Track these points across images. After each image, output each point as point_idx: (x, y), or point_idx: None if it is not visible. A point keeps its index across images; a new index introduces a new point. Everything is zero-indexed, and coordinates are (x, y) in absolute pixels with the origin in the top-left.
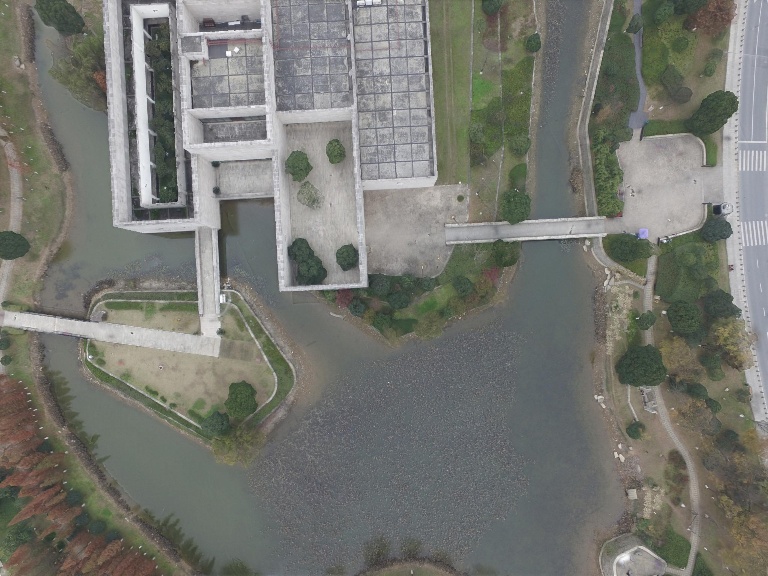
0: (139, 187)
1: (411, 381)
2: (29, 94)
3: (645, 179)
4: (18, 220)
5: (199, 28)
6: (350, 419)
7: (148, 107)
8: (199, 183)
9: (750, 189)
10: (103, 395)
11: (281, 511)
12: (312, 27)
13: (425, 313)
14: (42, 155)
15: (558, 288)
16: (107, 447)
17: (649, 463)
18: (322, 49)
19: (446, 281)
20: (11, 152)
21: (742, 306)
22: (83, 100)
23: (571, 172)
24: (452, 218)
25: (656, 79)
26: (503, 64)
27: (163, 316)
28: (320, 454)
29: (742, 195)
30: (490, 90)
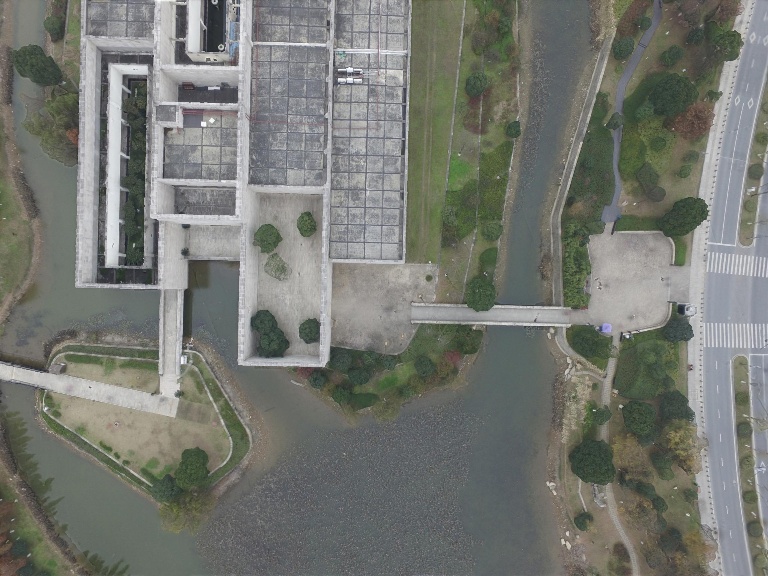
0: (105, 246)
1: (366, 454)
2: (3, 137)
3: (613, 273)
4: None
5: (178, 90)
6: (303, 487)
7: (121, 164)
8: (165, 250)
9: (715, 291)
10: None
11: (227, 573)
12: (291, 102)
13: (385, 389)
14: (12, 200)
15: (519, 372)
16: (61, 489)
17: (594, 553)
18: (299, 125)
19: (408, 359)
20: None
21: (698, 406)
22: (54, 156)
23: (541, 259)
24: (419, 297)
25: (632, 175)
26: (482, 147)
27: (123, 373)
28: (270, 520)
29: (707, 296)
30: (467, 172)
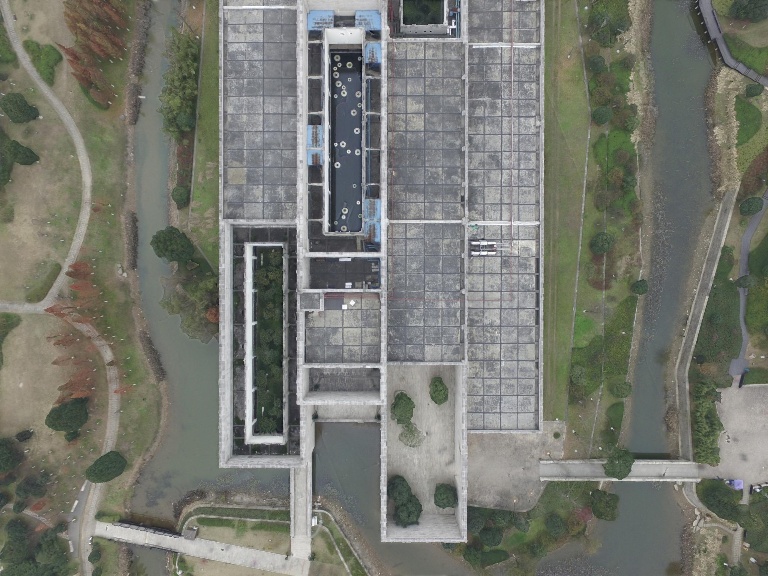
0: None
1: None
2: (130, 302)
3: (741, 426)
4: (114, 431)
5: (309, 262)
6: None
7: None
8: (306, 428)
9: None
10: None
11: None
12: (427, 278)
13: (514, 545)
14: (140, 365)
15: (646, 523)
16: None
17: None
18: (436, 301)
19: (537, 516)
20: None
21: None
22: (194, 337)
23: (666, 410)
24: (547, 454)
25: (759, 329)
26: (606, 302)
27: (254, 535)
28: None
29: None
30: (592, 328)
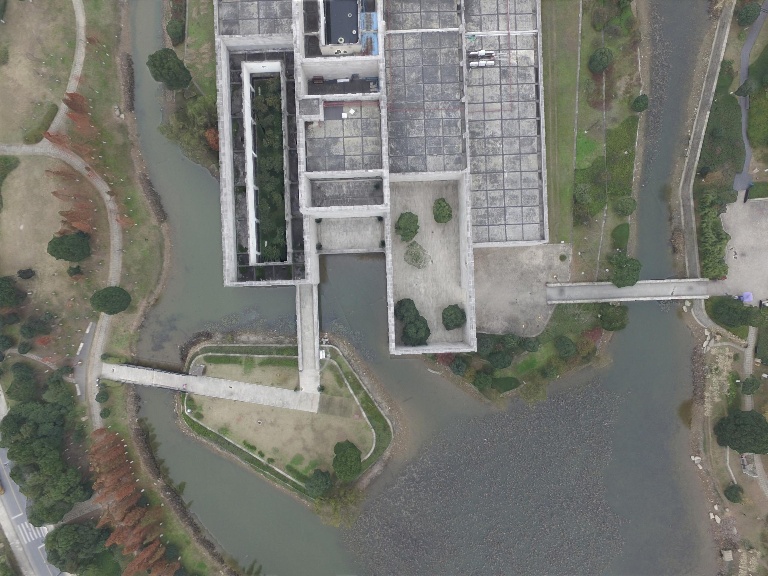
0: None
1: (508, 439)
2: (128, 144)
3: (748, 241)
4: (117, 272)
5: (307, 85)
6: (446, 475)
7: (253, 162)
8: (310, 244)
9: None
10: (198, 447)
11: (376, 566)
12: (426, 88)
13: (524, 372)
14: (141, 206)
15: (656, 348)
16: (191, 493)
17: (746, 525)
18: (436, 111)
19: (547, 340)
20: (111, 203)
21: None
22: (194, 158)
23: (672, 232)
24: (554, 277)
25: (762, 141)
26: (607, 123)
27: (262, 371)
28: (415, 510)
29: None
30: (594, 149)
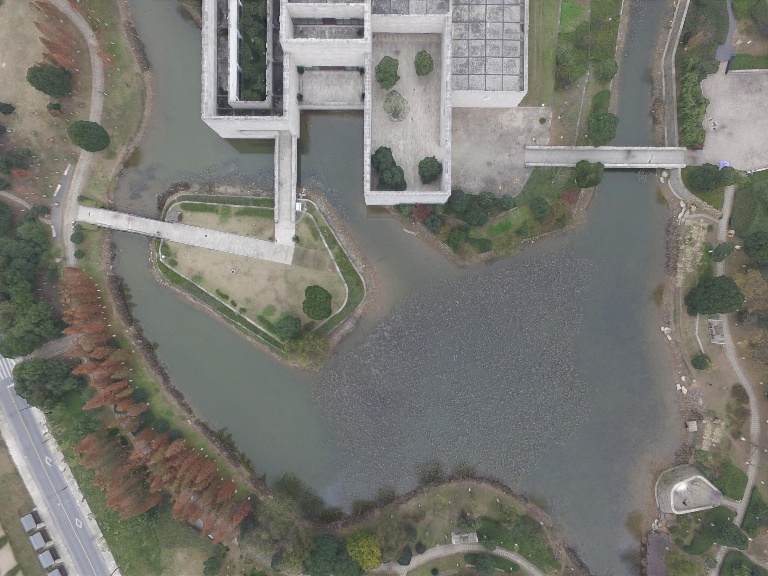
0: None
1: (480, 302)
2: None
3: (728, 113)
4: (98, 115)
5: None
6: (417, 336)
7: (237, 7)
8: (289, 82)
9: None
10: (171, 298)
11: (343, 423)
12: None
13: (499, 234)
14: (124, 52)
15: (632, 218)
16: (164, 358)
17: (711, 396)
18: None
19: (523, 203)
20: (94, 47)
21: None
22: None
23: (653, 103)
24: (533, 140)
25: (746, 13)
26: None
27: (238, 221)
28: (385, 369)
29: None
30: (579, 14)
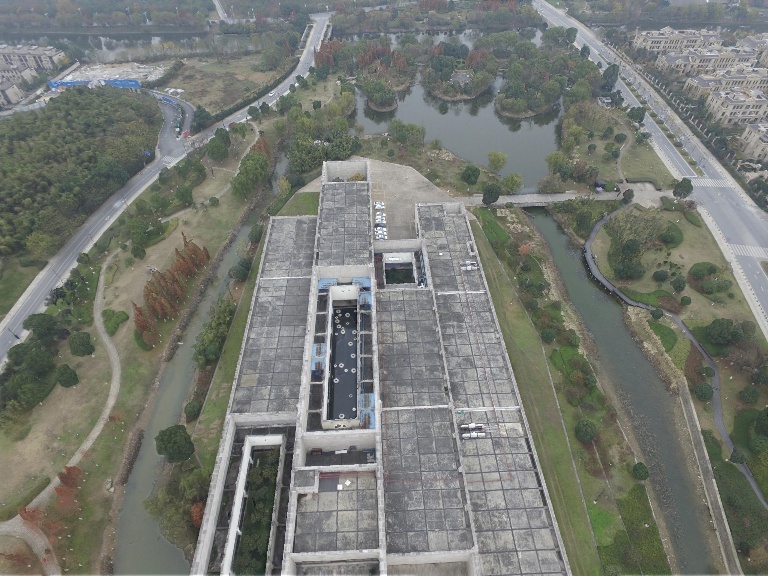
0: None
1: None
2: (106, 521)
3: None
4: None
5: (306, 456)
6: None
7: (235, 541)
8: None
9: None
10: None
11: None
12: (422, 459)
13: None
14: None
15: None
16: None
17: None
18: (434, 481)
19: None
20: None
21: None
22: (170, 537)
23: None
24: None
25: None
26: (614, 492)
27: None
28: None
29: None
30: (610, 522)
